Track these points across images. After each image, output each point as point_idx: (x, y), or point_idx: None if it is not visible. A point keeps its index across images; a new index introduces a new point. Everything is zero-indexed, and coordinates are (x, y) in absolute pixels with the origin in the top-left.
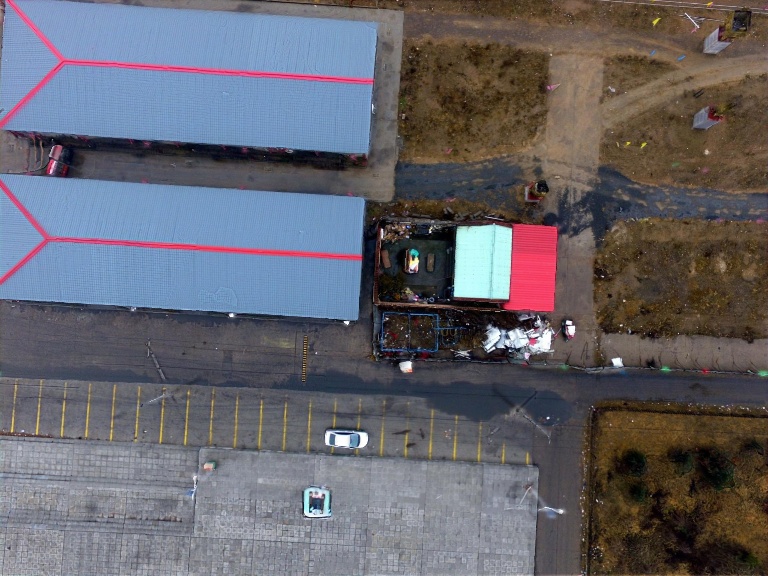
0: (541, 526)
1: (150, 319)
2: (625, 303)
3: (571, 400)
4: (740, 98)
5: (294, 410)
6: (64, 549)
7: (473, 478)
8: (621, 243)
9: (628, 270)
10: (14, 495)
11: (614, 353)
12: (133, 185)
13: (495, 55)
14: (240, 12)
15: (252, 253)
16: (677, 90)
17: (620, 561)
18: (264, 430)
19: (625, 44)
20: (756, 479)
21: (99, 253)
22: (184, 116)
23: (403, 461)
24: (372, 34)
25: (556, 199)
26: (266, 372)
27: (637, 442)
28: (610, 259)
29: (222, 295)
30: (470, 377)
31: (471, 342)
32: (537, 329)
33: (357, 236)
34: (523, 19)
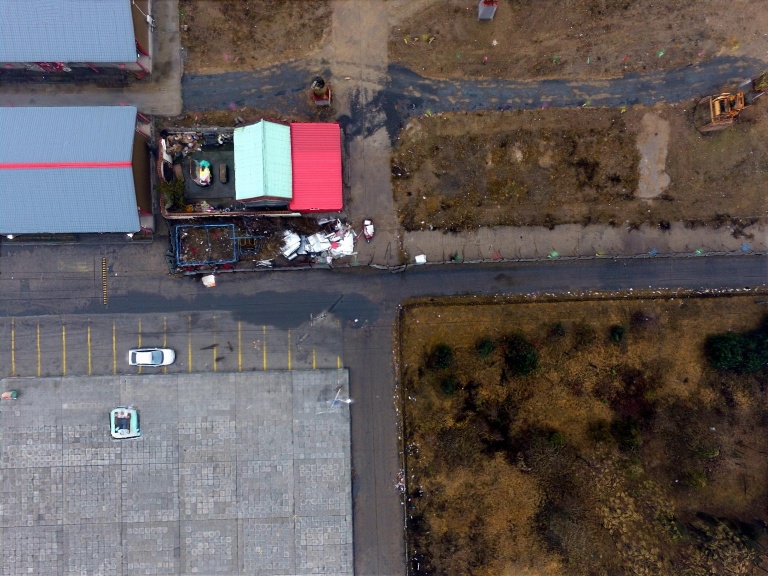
0: (356, 428)
1: None
2: (425, 200)
3: (378, 301)
4: None
5: (97, 334)
6: None
7: (282, 385)
8: (417, 140)
9: (426, 167)
10: None
11: (417, 250)
12: None
13: None
14: None
15: (17, 168)
16: None
17: (436, 455)
18: (68, 356)
19: None
20: (564, 363)
21: None
22: None
23: (210, 374)
24: None
25: (348, 101)
26: (66, 298)
27: (445, 336)
28: (407, 157)
29: None
30: (275, 286)
31: None
32: (337, 232)
33: (127, 144)
34: None
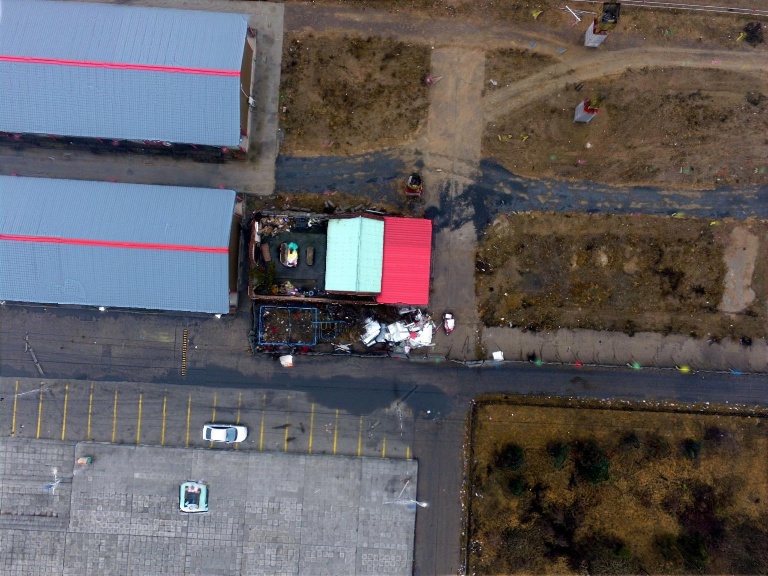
0: (421, 520)
1: (28, 313)
2: (507, 296)
3: (452, 394)
4: (621, 91)
5: (173, 404)
6: None
7: (351, 472)
8: (503, 236)
9: (510, 263)
10: None
11: (495, 347)
12: (1, 178)
13: (377, 48)
14: (117, 4)
15: (117, 246)
16: (559, 83)
17: (499, 555)
18: (143, 424)
19: (507, 37)
20: (635, 472)
21: None
22: (52, 108)
23: (281, 455)
24: (242, 26)
25: (438, 192)
26: (145, 366)
27: (517, 436)
28: (492, 252)
29: (69, 287)
30: (351, 371)
31: None
32: (417, 323)
33: (225, 229)
34: (405, 12)
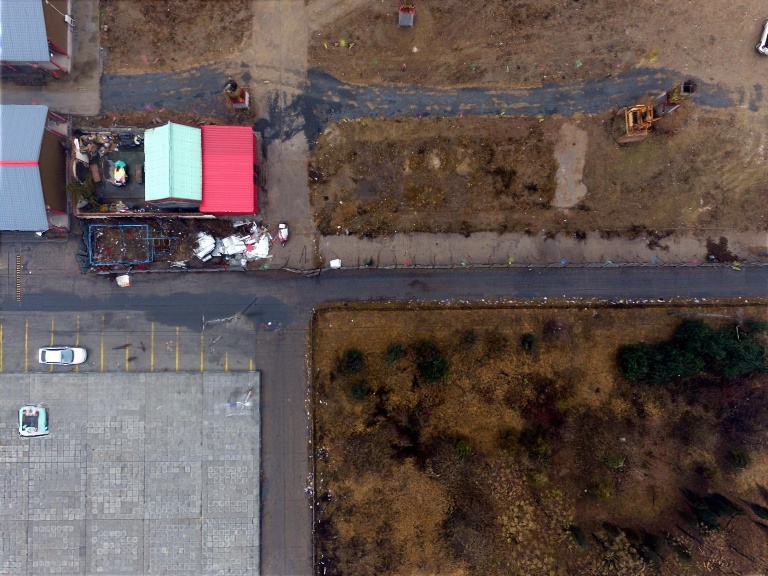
0: (267, 431)
1: None
2: (342, 205)
3: (292, 304)
4: None
5: (10, 331)
6: None
7: (193, 387)
8: (335, 145)
9: (343, 171)
10: None
11: (333, 255)
12: None
13: None
14: None
15: None
16: None
17: (345, 460)
18: None
19: None
20: (476, 370)
21: None
22: None
23: (121, 374)
24: None
25: (267, 104)
26: None
27: (357, 341)
28: (324, 161)
29: None
30: (189, 287)
31: None
32: (252, 235)
33: (36, 143)
34: None
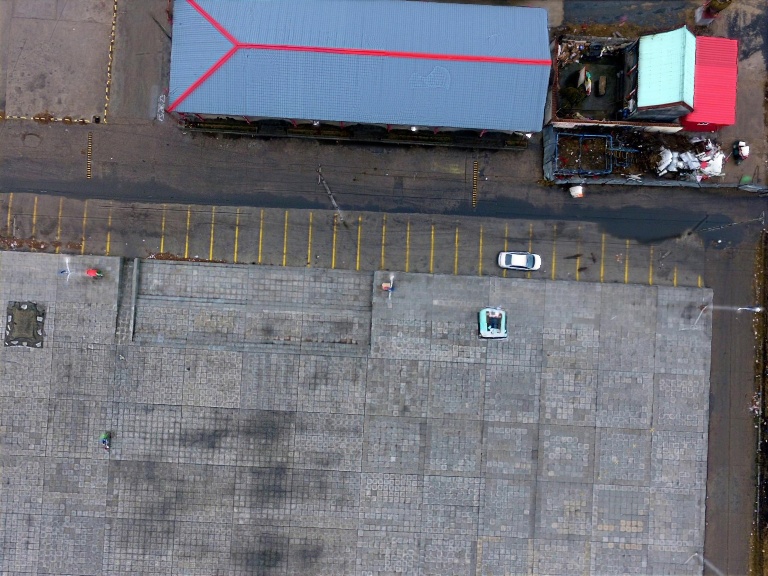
0: (714, 348)
1: (320, 146)
2: None
3: (742, 223)
4: None
5: (465, 235)
6: (243, 370)
7: (647, 299)
8: None
9: None
10: (191, 318)
11: None
12: None
13: None
14: None
15: (441, 59)
16: None
17: None
18: (436, 255)
19: None
20: None
21: (288, 60)
22: None
23: (577, 283)
24: None
25: (726, 22)
26: (437, 198)
27: None
28: None
29: (437, 75)
30: (641, 201)
31: (644, 164)
32: (709, 152)
33: (544, 43)
34: None
